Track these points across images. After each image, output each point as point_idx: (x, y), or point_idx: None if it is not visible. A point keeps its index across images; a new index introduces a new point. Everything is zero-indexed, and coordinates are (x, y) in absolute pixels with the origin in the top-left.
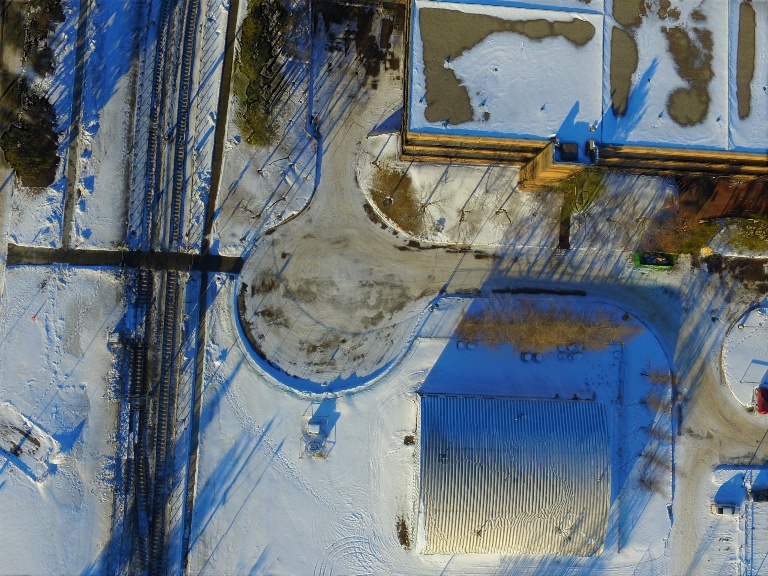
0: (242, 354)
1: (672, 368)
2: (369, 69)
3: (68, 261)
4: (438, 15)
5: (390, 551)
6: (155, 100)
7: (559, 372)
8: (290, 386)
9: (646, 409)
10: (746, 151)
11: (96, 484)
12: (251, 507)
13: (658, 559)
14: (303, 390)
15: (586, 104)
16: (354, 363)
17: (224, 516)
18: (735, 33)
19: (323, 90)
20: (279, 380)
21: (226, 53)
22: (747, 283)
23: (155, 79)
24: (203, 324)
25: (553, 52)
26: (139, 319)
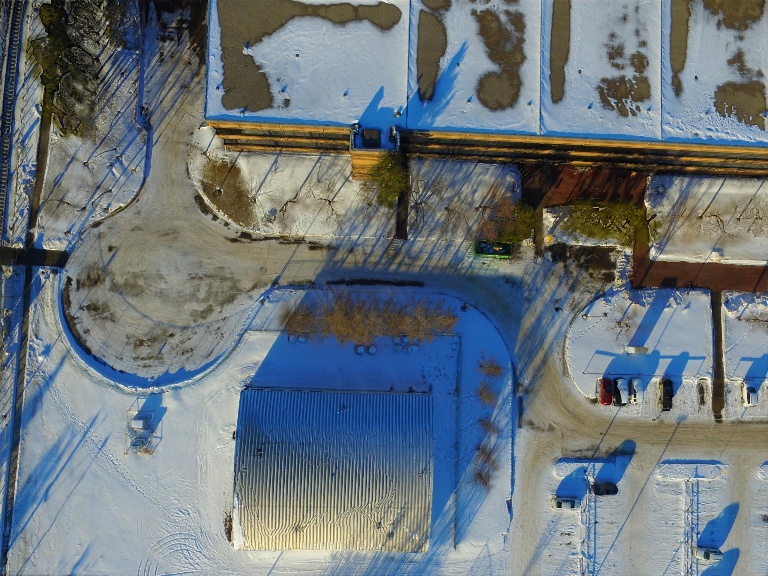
0: (66, 349)
1: (513, 359)
2: (202, 58)
3: None
4: (237, 0)
5: (217, 548)
6: None
7: (394, 364)
8: (115, 381)
9: (481, 401)
10: (558, 136)
11: None
12: (74, 504)
13: (497, 554)
14: (129, 385)
15: (391, 89)
16: (183, 357)
17: (46, 513)
18: (549, 15)
19: (154, 80)
20: (104, 375)
21: None
22: (592, 272)
23: None
24: (26, 319)
25: (357, 37)
26: None
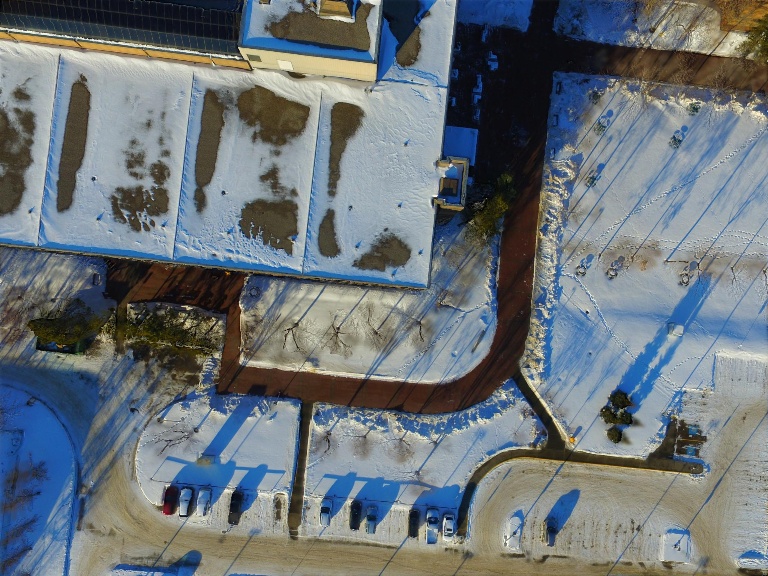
0: None
1: (79, 459)
2: None
3: None
4: None
5: None
6: None
7: None
8: None
9: (29, 503)
10: (58, 248)
11: None
12: None
13: None
14: None
15: None
16: None
17: None
18: (62, 116)
19: None
20: None
21: None
22: (175, 374)
23: None
24: None
25: None
26: None
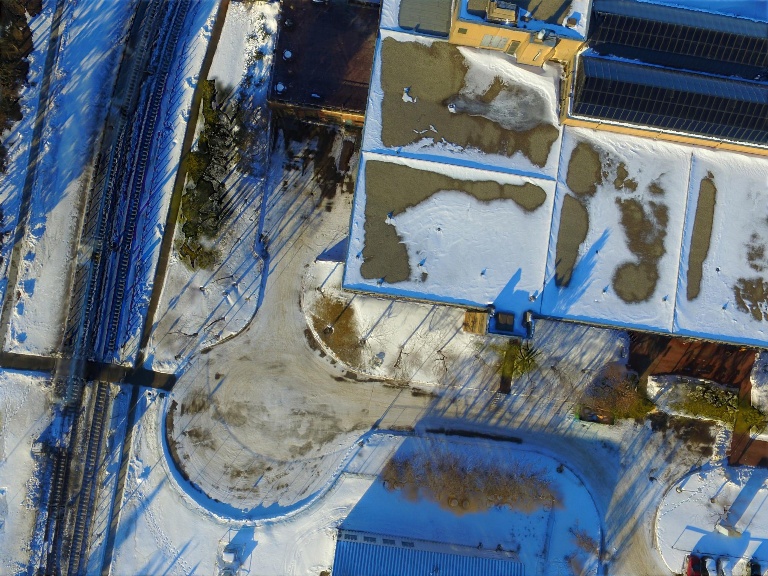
0: (165, 473)
1: (603, 526)
2: (325, 190)
3: (1, 363)
4: (385, 169)
5: None
6: (105, 206)
7: (485, 520)
8: (210, 510)
9: (569, 569)
10: (690, 335)
11: None
12: None
13: None
14: (223, 515)
15: (528, 272)
16: (277, 492)
17: None
18: (692, 210)
19: (276, 209)
20: (199, 503)
21: (181, 164)
22: (691, 445)
23: (107, 185)
24: (129, 439)
25: (500, 216)
26: (66, 428)
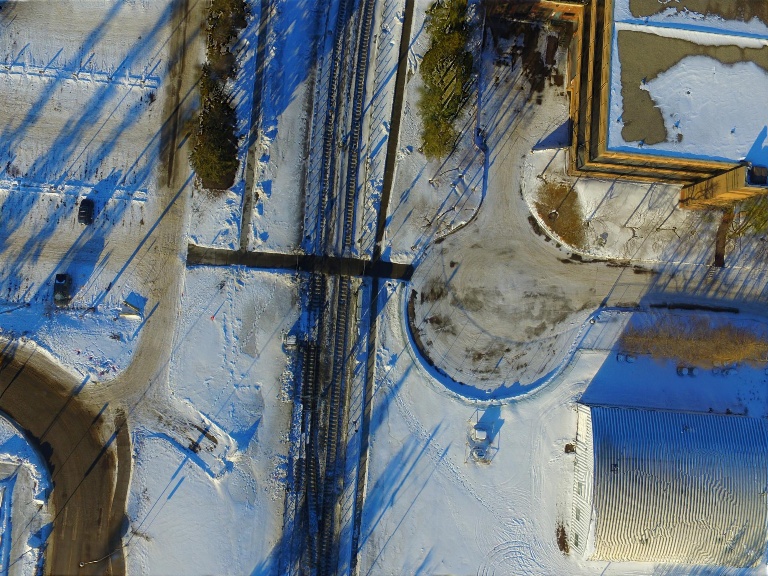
0: (411, 360)
1: None
2: (534, 84)
3: (245, 263)
4: (635, 38)
5: (550, 556)
6: (330, 108)
7: (713, 387)
8: (457, 392)
9: None
10: None
11: (269, 482)
12: (418, 509)
13: None
14: (469, 397)
15: None
16: (517, 372)
17: (392, 517)
18: None
19: (490, 103)
20: (446, 386)
21: (400, 64)
22: None
23: (330, 87)
24: (374, 329)
25: (743, 77)
26: (312, 322)
